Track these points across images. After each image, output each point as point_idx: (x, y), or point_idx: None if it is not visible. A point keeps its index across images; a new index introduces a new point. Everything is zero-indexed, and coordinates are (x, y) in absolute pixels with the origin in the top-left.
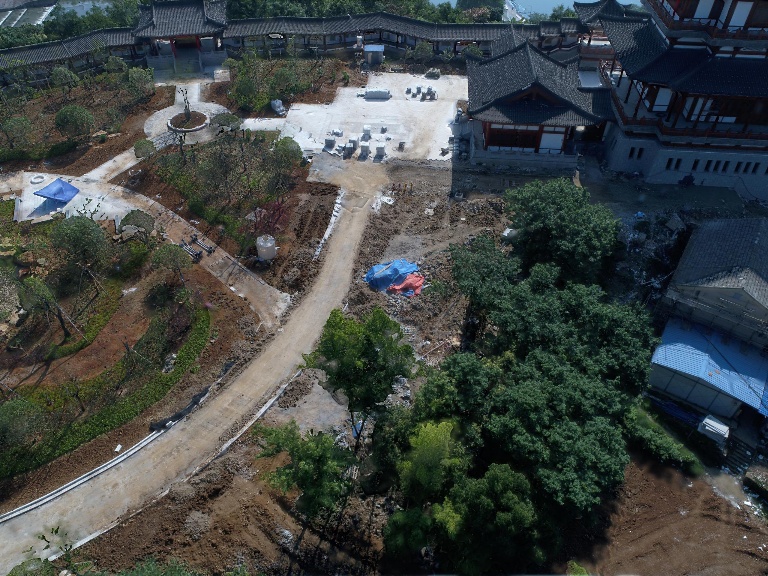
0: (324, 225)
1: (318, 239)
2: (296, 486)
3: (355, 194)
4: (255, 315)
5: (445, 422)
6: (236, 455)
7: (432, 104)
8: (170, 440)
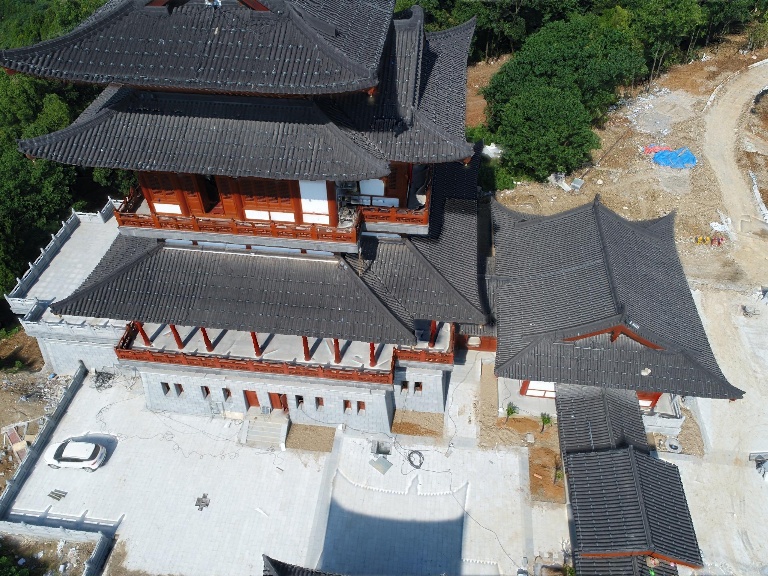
0: (767, 201)
1: (762, 186)
2: (672, 79)
3: (761, 236)
4: (763, 138)
5: (620, 9)
6: (712, 84)
7: (753, 440)
8: (754, 89)
